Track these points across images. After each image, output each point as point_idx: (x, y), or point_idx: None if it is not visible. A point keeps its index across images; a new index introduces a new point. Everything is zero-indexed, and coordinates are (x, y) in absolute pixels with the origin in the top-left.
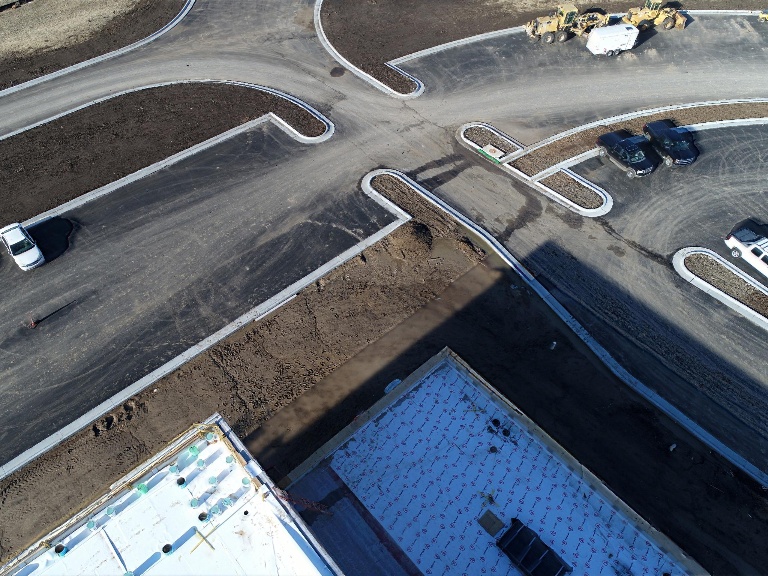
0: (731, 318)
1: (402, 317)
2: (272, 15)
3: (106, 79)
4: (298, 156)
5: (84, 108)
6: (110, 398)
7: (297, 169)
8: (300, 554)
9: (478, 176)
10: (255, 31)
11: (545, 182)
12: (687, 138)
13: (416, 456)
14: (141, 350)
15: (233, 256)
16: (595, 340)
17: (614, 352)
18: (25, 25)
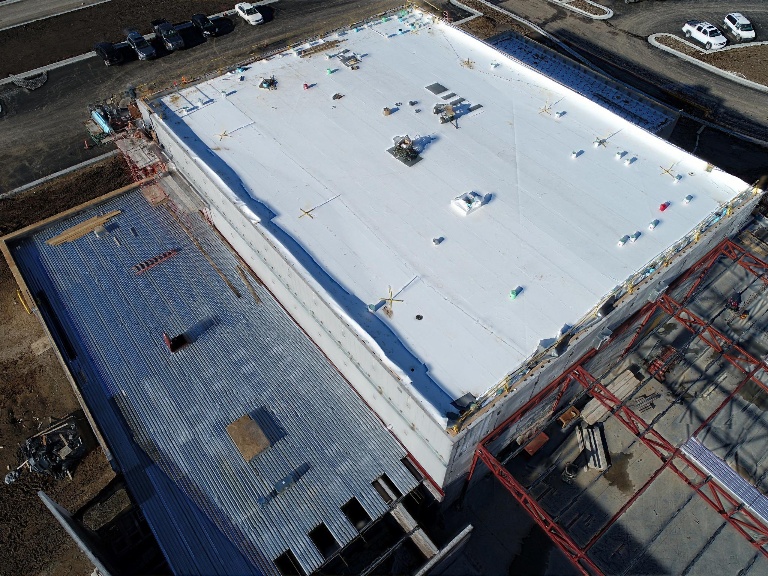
0: (679, 61)
1: None
2: None
3: None
4: None
5: None
6: None
7: None
8: (457, 31)
9: None
10: None
11: (570, 4)
12: None
13: None
14: None
15: None
16: (595, 65)
17: (606, 70)
18: None
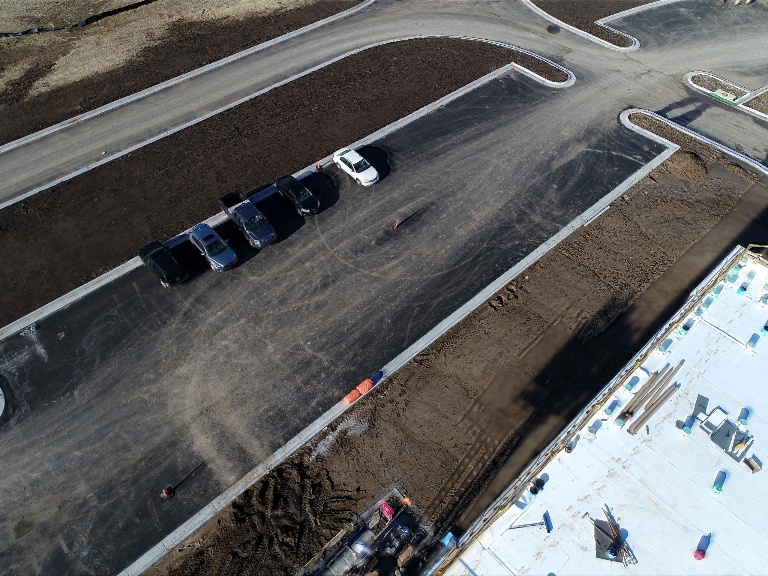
0: None
1: (712, 223)
2: None
3: (348, 35)
4: (553, 98)
5: (344, 58)
6: (492, 282)
7: (558, 108)
8: None
9: (721, 115)
10: None
11: None
12: None
13: None
14: (498, 247)
15: (537, 177)
16: None
17: None
18: None
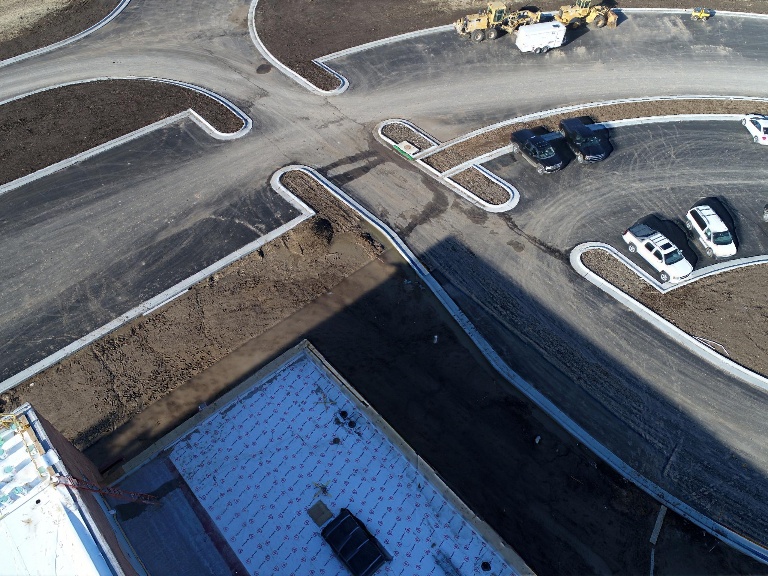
0: (619, 312)
1: (290, 311)
2: (207, 12)
3: (30, 76)
4: (211, 152)
5: (3, 104)
6: None
7: (208, 165)
8: (77, 541)
9: (389, 172)
10: (187, 28)
11: (455, 178)
12: (603, 135)
13: (257, 447)
14: (23, 344)
15: (131, 251)
16: (480, 334)
17: (497, 346)
18: None
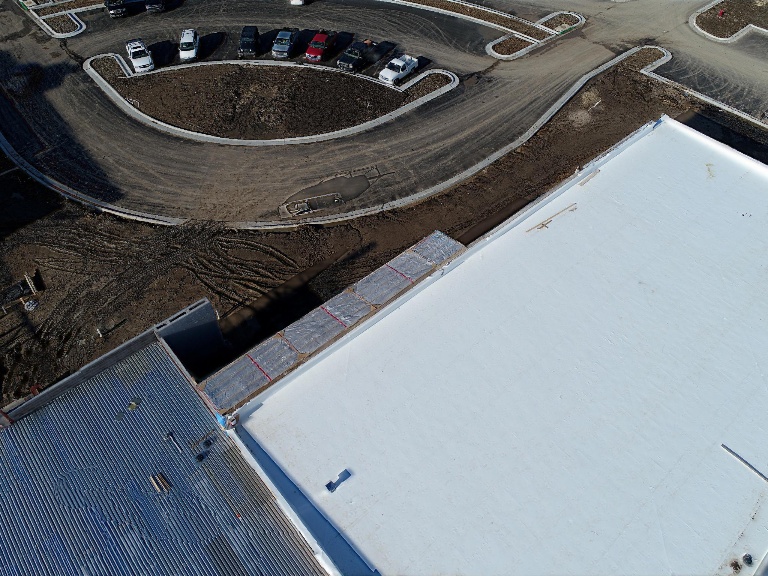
0: (90, 87)
1: None
2: None
3: None
4: None
5: None
6: None
7: None
8: None
9: (3, 16)
10: None
11: (48, 20)
12: None
13: None
14: None
15: None
16: None
17: None
18: None
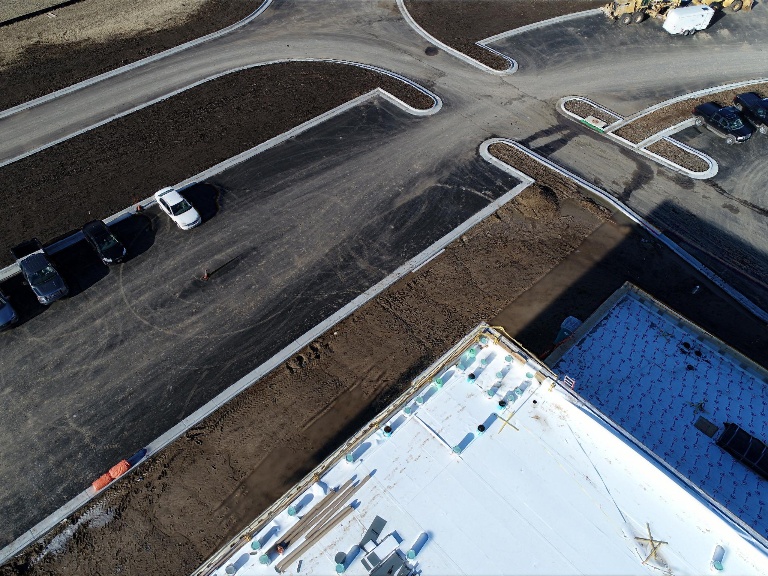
0: None
1: (549, 267)
2: None
3: (212, 58)
4: (414, 127)
5: (200, 85)
6: (296, 340)
7: (416, 139)
8: (602, 430)
9: (586, 144)
10: (344, 14)
11: (651, 149)
12: None
13: (623, 373)
14: (312, 299)
15: (376, 216)
16: (730, 286)
17: (750, 296)
18: (119, 10)
